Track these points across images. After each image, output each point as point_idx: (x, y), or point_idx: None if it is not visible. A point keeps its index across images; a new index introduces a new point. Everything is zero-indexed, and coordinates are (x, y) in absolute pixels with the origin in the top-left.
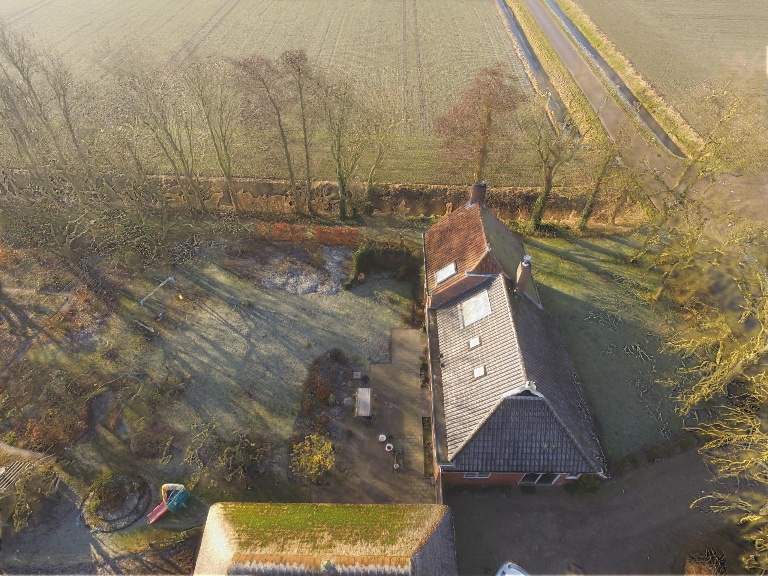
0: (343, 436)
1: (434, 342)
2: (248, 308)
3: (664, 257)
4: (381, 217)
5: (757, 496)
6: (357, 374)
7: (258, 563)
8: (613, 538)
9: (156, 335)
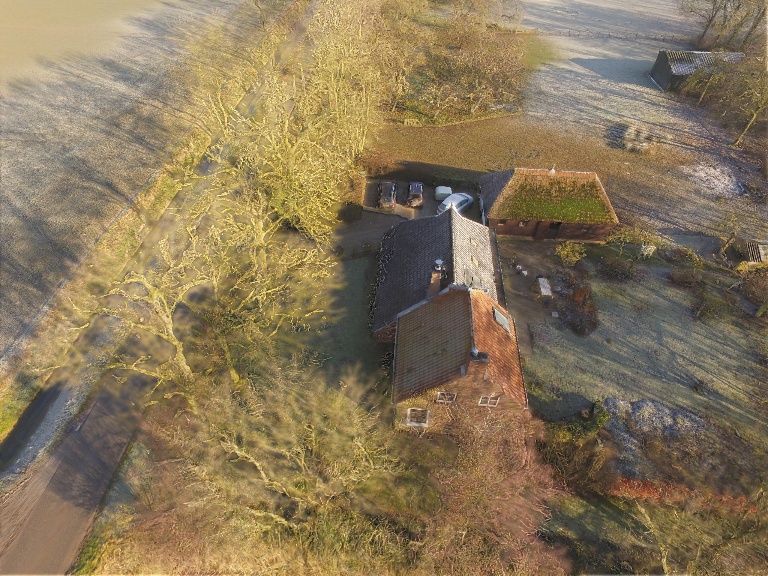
0: (553, 278)
1: (501, 295)
2: (695, 385)
3: (169, 444)
4: (591, 571)
5: (287, 240)
6: (555, 314)
7: (584, 173)
8: (386, 229)
9: (765, 362)
